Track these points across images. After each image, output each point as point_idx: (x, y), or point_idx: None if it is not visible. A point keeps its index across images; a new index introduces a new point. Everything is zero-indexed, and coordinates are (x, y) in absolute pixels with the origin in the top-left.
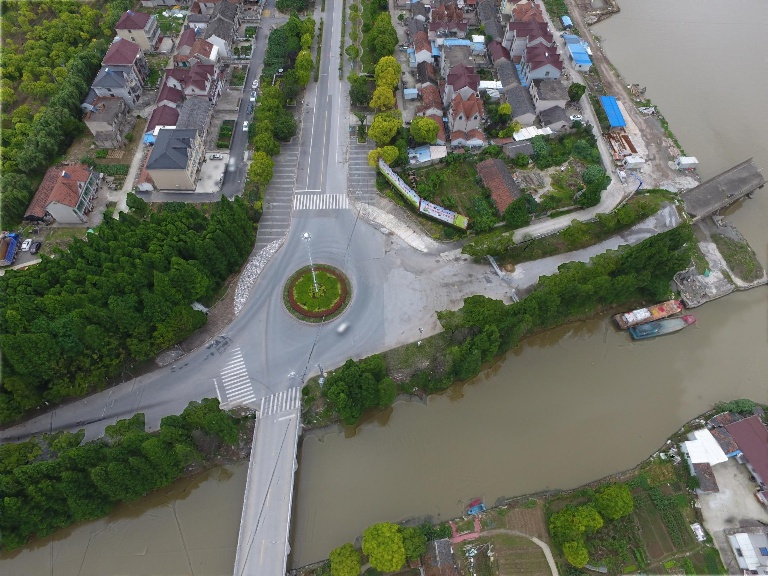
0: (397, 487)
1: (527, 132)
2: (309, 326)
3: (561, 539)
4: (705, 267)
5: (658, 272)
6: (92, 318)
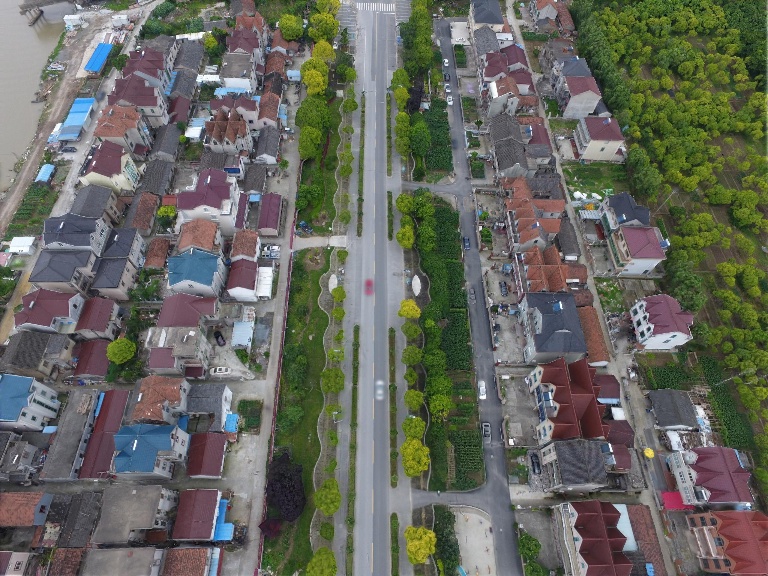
0: None
1: (199, 36)
2: None
3: None
4: None
5: None
6: None
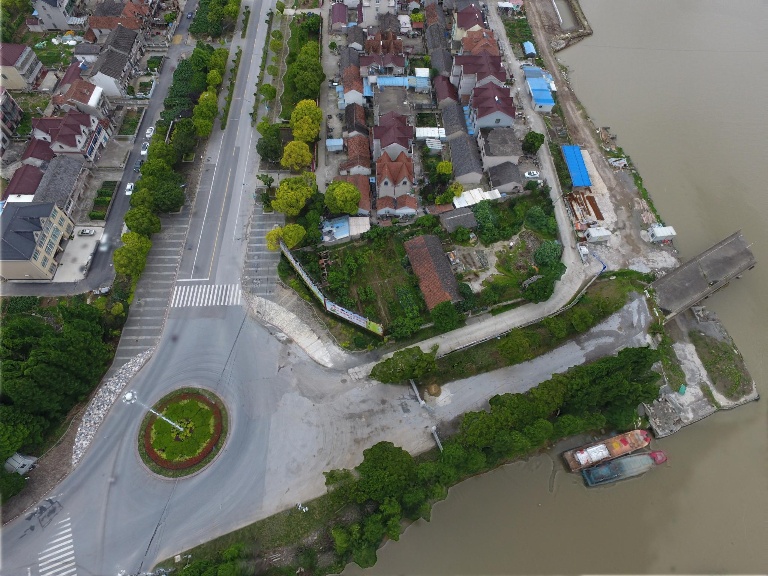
0: None
1: (470, 196)
2: (166, 482)
3: None
4: (680, 381)
5: (618, 403)
6: None
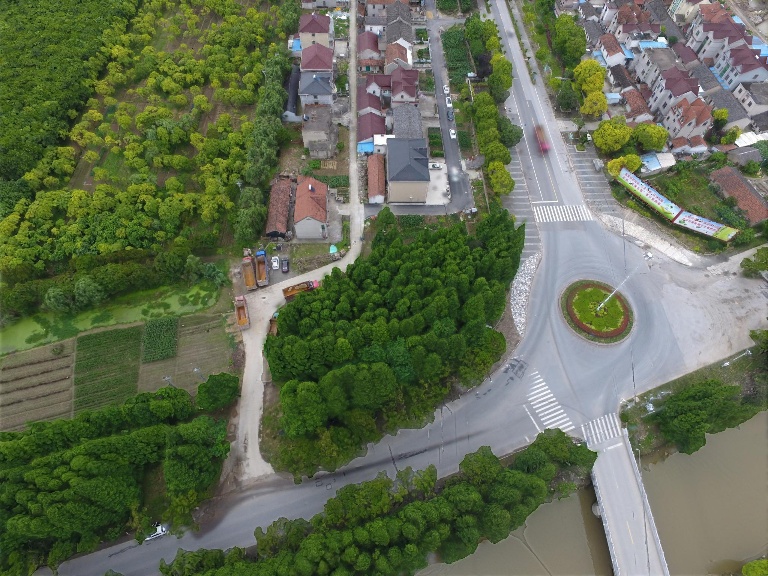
0: (717, 516)
1: (747, 138)
2: (601, 347)
3: None
4: None
5: None
6: (429, 346)
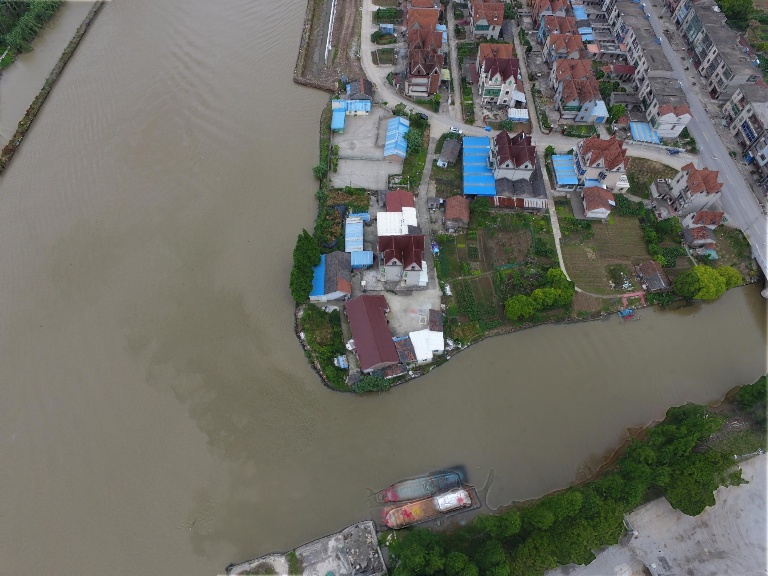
0: None
1: None
2: None
3: (571, 282)
4: None
5: (442, 551)
6: None
